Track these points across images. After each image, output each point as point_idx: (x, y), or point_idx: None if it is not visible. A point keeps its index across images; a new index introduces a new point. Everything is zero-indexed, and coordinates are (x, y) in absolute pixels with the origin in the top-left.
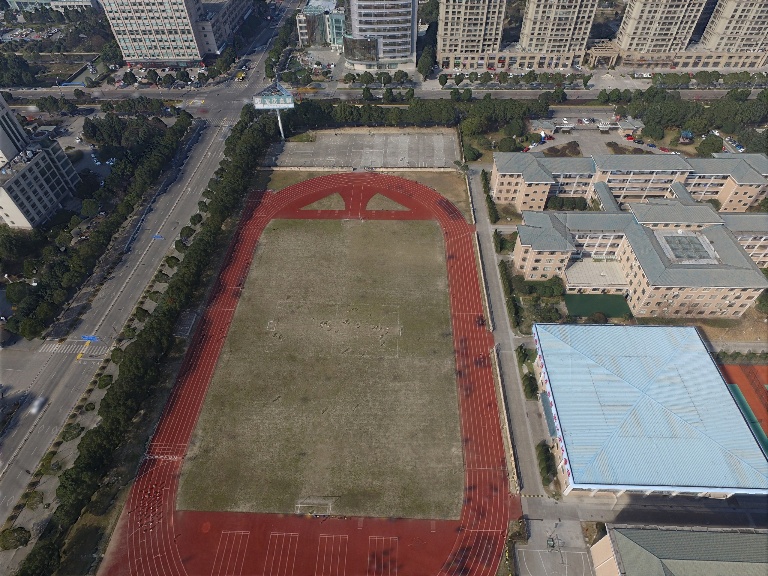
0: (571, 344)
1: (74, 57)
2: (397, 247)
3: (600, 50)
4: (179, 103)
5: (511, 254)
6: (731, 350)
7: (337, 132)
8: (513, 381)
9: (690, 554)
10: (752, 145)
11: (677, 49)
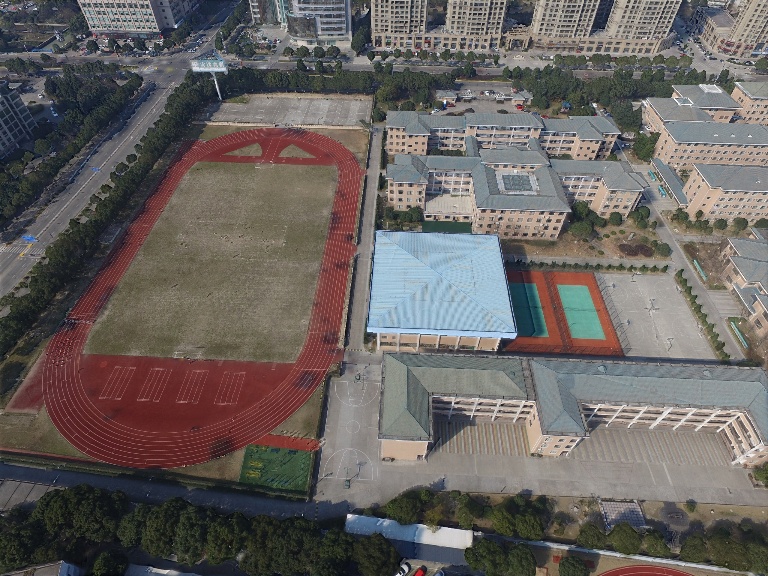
0: (398, 244)
1: (46, 28)
2: (297, 184)
3: (514, 34)
4: (135, 69)
5: (386, 190)
6: (541, 261)
7: (269, 96)
8: (363, 278)
9: (430, 365)
10: (617, 114)
11: (582, 35)
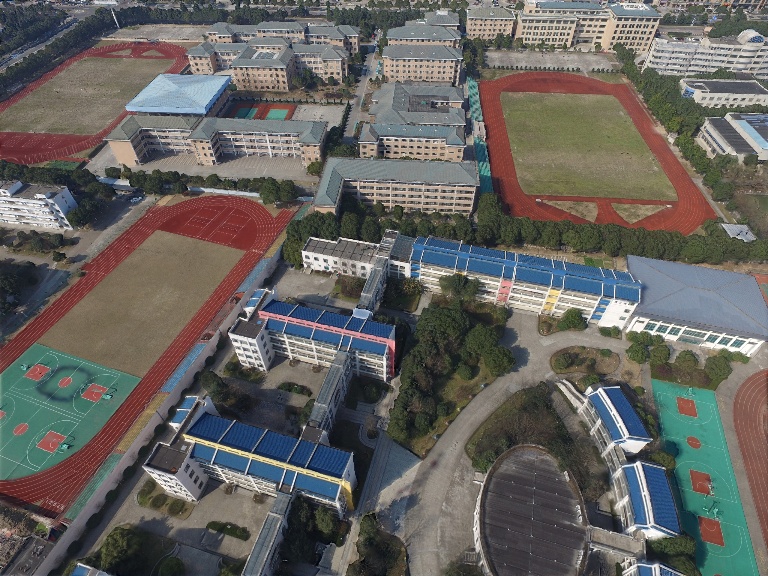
0: (168, 78)
1: None
2: (144, 67)
3: None
4: (68, 12)
5: None
6: None
7: (154, 26)
8: None
9: None
10: None
11: None
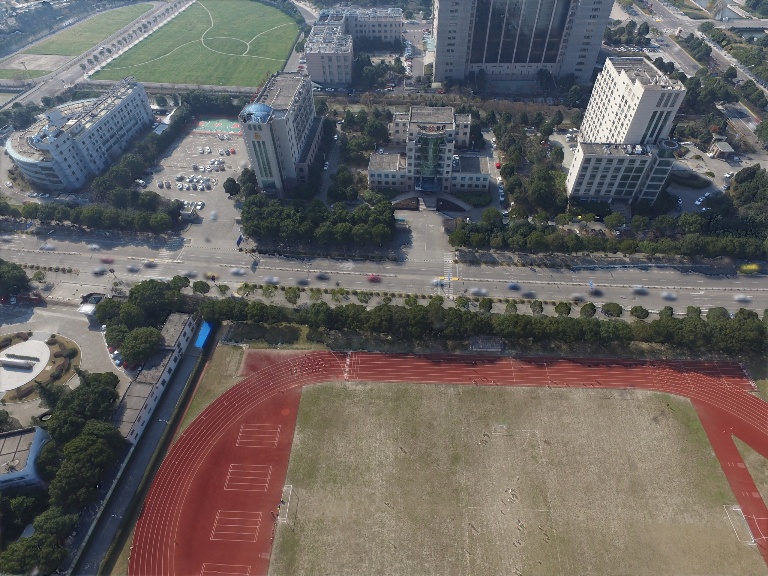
0: None
1: None
2: None
3: None
4: None
5: None
6: None
7: None
8: None
9: None
10: None
11: None
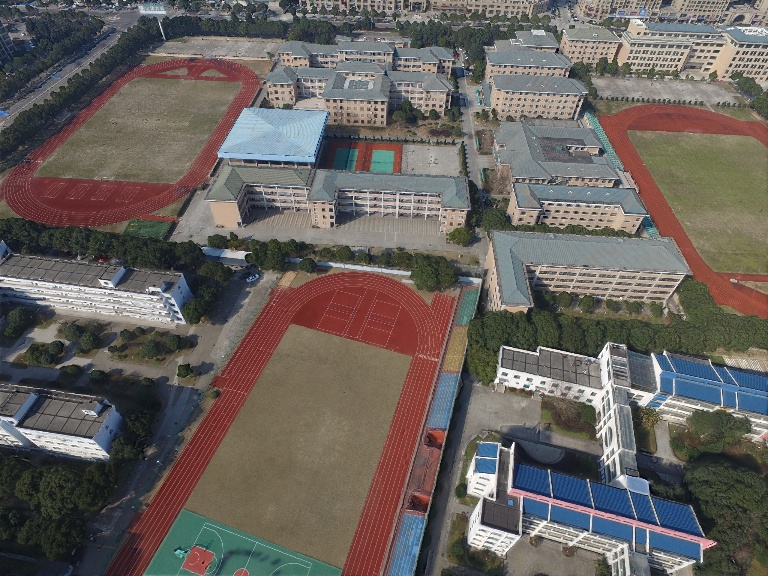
0: (256, 114)
1: None
2: (208, 92)
3: None
4: (101, 18)
5: None
6: None
7: (204, 38)
8: None
9: None
10: (470, 53)
11: None
